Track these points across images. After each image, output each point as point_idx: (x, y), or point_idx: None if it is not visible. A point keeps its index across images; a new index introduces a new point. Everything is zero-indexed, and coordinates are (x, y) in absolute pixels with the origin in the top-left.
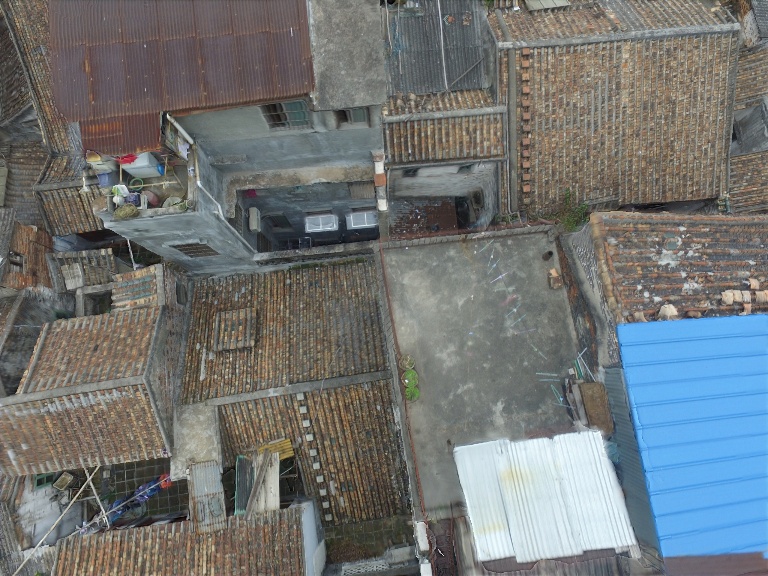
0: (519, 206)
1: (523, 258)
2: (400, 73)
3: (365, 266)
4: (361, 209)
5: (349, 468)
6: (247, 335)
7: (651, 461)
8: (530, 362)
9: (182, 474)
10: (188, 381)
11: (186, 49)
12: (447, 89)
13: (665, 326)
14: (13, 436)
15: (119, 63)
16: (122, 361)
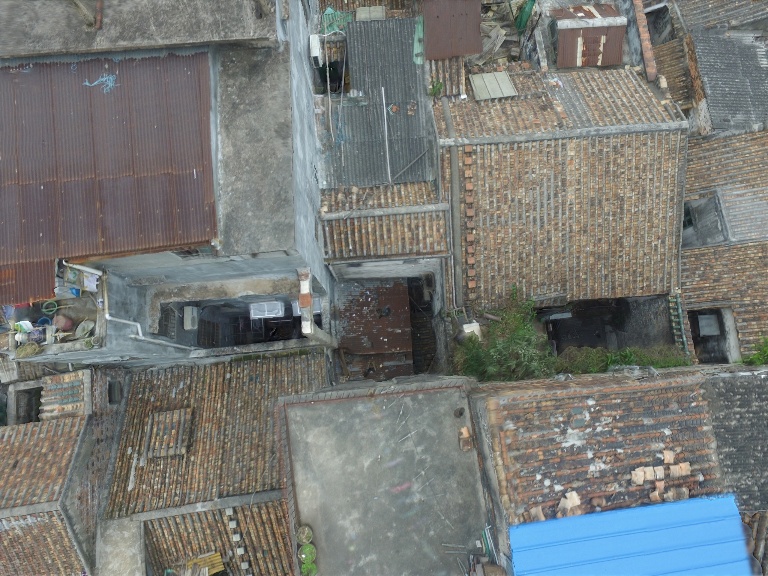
0: (464, 301)
1: (434, 414)
2: (342, 165)
3: (308, 359)
4: None
5: None
6: (178, 441)
7: None
8: (436, 531)
9: None
10: (116, 491)
11: (84, 191)
12: (390, 182)
13: (562, 525)
14: None
15: (14, 206)
16: (40, 481)
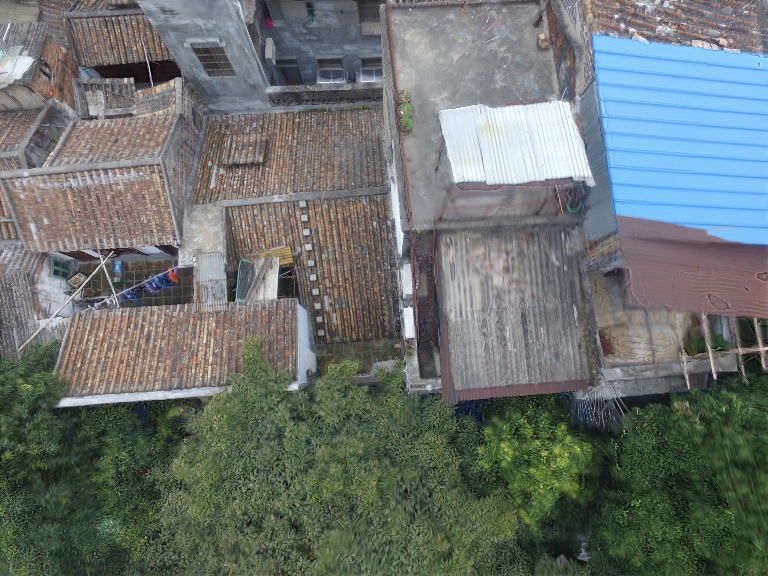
0: None
1: (516, 24)
2: None
3: (371, 112)
4: (370, 65)
5: (343, 283)
6: (256, 152)
7: (613, 143)
8: None
9: (189, 262)
10: (199, 188)
11: None
12: None
13: (636, 44)
14: (36, 210)
15: None
16: (140, 149)
